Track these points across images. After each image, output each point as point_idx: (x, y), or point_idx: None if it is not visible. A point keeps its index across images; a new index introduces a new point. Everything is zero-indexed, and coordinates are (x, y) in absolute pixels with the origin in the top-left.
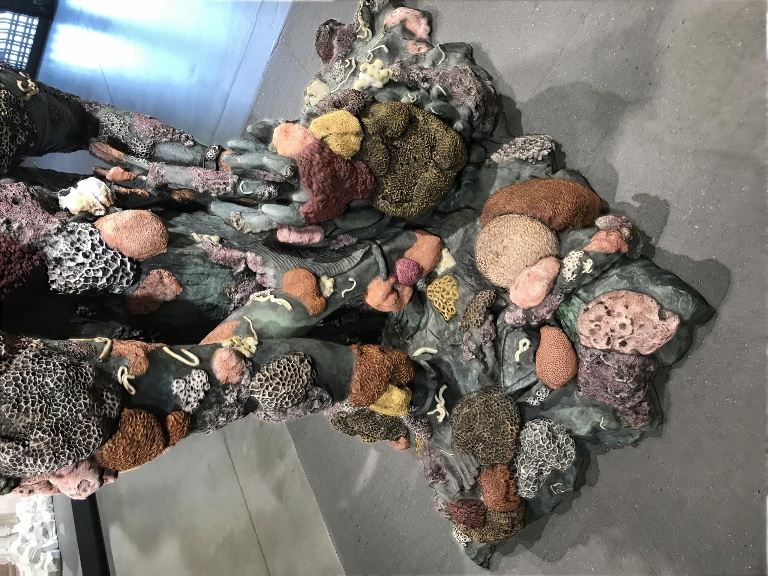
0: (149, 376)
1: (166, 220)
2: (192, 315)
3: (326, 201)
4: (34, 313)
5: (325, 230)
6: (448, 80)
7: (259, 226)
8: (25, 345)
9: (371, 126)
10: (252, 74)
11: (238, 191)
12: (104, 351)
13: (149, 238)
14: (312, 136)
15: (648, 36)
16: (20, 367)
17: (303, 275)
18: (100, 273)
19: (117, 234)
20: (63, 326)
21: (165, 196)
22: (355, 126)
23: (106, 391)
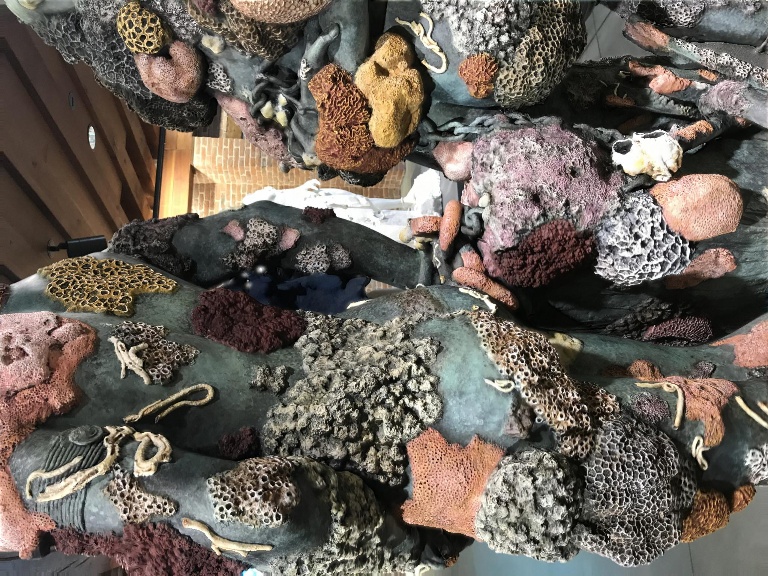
0: (723, 446)
1: (725, 160)
2: (735, 289)
3: None
4: (568, 286)
5: None
6: None
7: None
8: (603, 408)
9: None
10: None
11: None
12: (679, 414)
13: (722, 221)
14: None
15: None
16: (607, 452)
17: None
18: (658, 268)
19: (684, 216)
20: (592, 296)
21: (728, 121)
22: None
23: (684, 475)
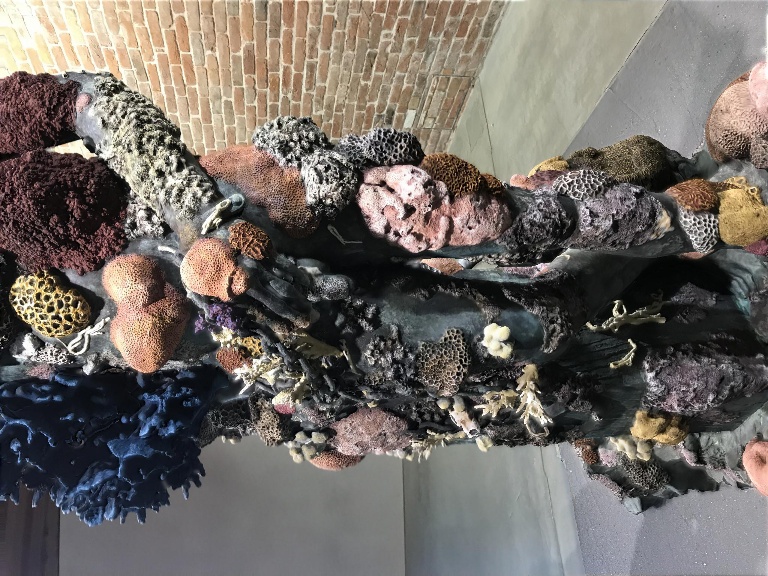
0: None
1: None
2: None
3: None
4: None
5: None
6: None
7: None
8: None
9: None
10: (567, 515)
11: None
12: None
13: None
14: None
15: (712, 34)
16: None
17: None
18: None
19: None
20: None
21: None
22: None
23: None
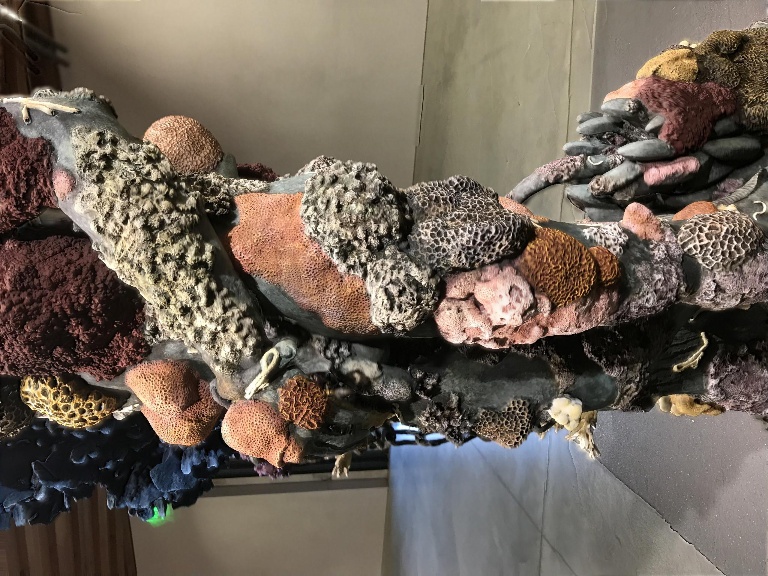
0: (553, 224)
1: None
2: None
3: (684, 113)
4: None
5: (698, 159)
6: (766, 21)
7: (622, 175)
8: None
9: (700, 50)
10: None
11: (588, 164)
12: None
13: (515, 210)
14: (642, 80)
15: None
16: None
17: (693, 204)
18: None
19: None
20: None
21: None
22: (683, 51)
23: None
